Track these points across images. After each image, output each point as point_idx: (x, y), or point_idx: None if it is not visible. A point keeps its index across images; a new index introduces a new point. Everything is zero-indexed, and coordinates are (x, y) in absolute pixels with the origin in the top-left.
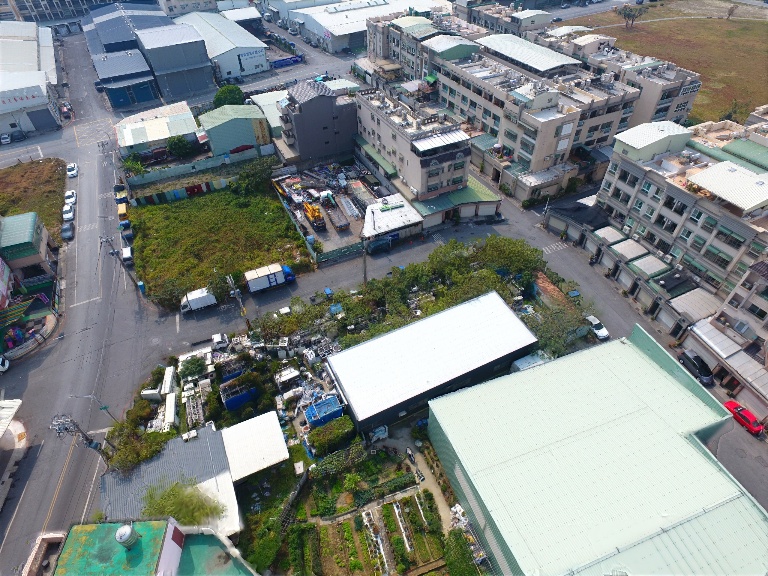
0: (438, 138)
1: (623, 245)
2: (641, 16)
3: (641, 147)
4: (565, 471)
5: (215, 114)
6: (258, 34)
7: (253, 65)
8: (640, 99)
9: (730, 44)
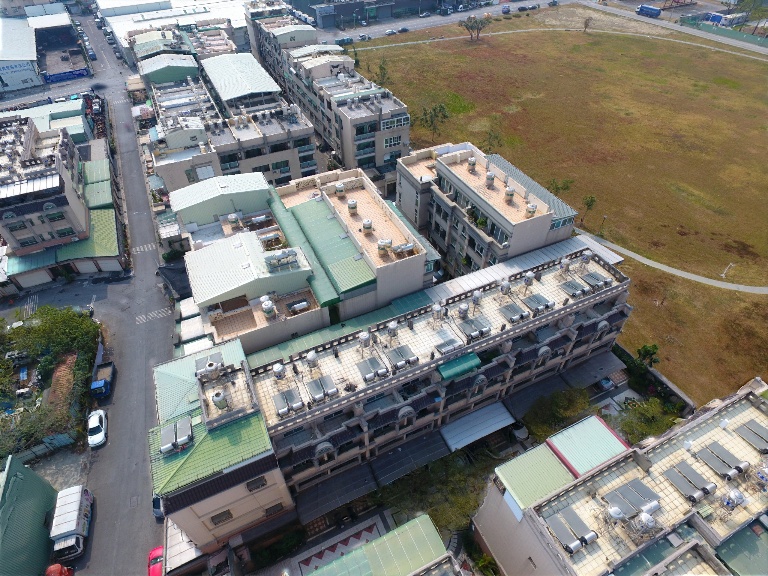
0: (18, 186)
1: (195, 320)
2: (497, 27)
3: (178, 209)
4: None
5: None
6: (72, 42)
7: (19, 80)
8: (343, 133)
9: (565, 61)
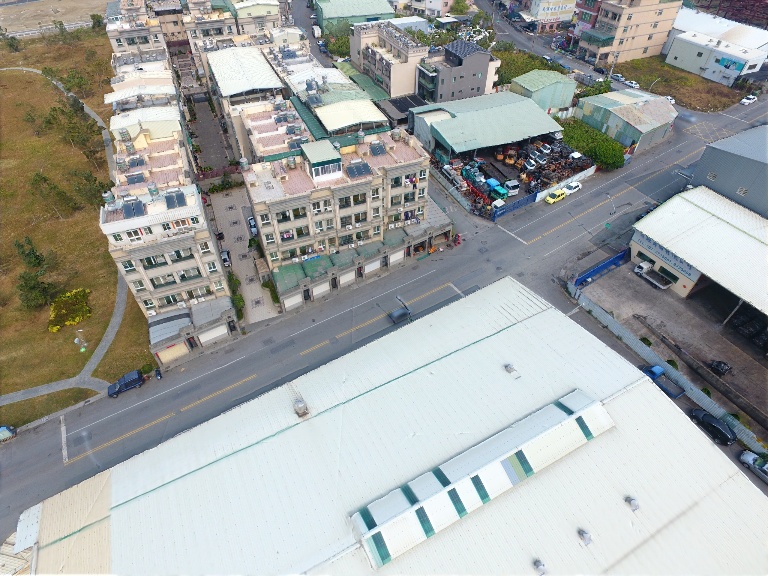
0: None
1: None
2: None
3: None
4: (364, 0)
5: (560, 77)
6: None
7: None
8: None
9: None
